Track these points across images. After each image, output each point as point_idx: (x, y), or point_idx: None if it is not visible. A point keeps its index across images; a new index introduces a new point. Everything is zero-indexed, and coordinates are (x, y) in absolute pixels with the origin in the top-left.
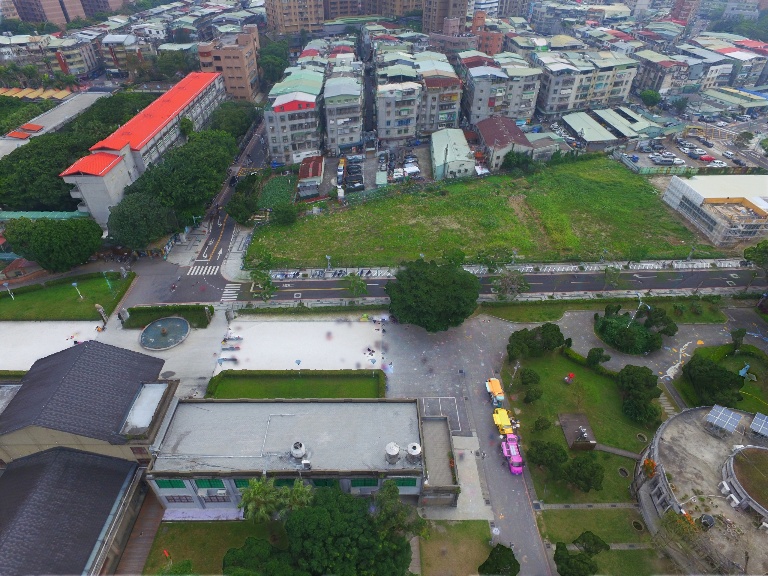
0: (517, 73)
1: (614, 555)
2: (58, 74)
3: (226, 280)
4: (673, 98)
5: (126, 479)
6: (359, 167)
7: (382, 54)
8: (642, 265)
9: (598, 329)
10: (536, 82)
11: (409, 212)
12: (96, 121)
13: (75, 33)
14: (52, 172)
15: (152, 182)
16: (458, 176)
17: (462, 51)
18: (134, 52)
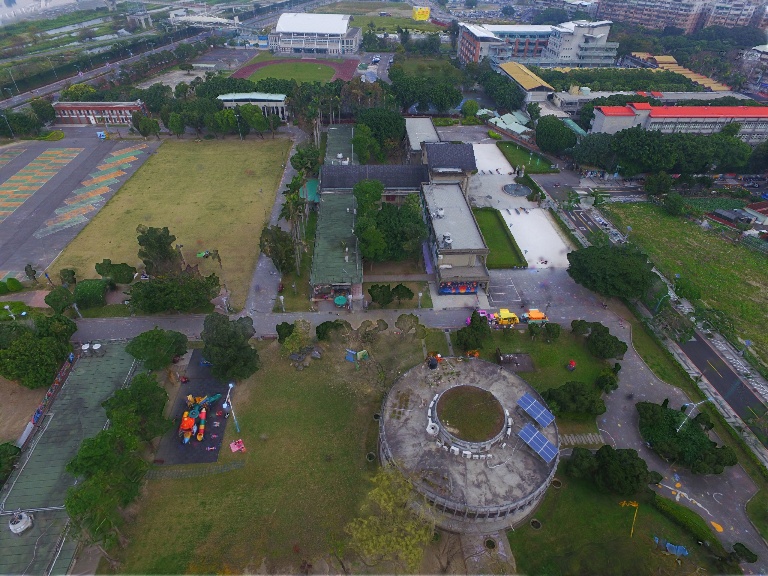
0: None
1: (421, 359)
2: (737, 74)
3: None
4: None
5: None
6: None
7: None
8: None
9: None
10: None
11: None
12: (691, 105)
13: None
14: None
15: (622, 132)
16: None
17: None
18: None
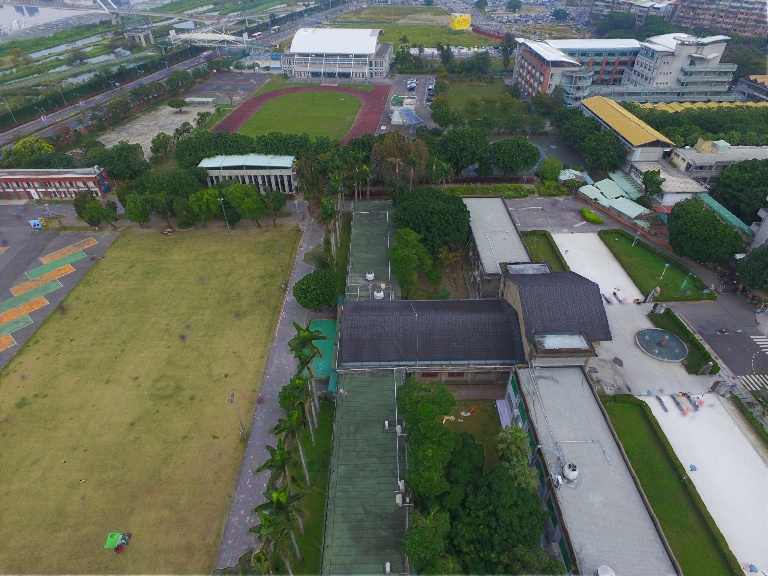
0: None
1: None
2: None
3: None
4: None
5: (511, 360)
6: None
7: None
8: None
9: None
10: None
11: None
12: None
13: None
14: None
15: None
16: None
17: None
18: None
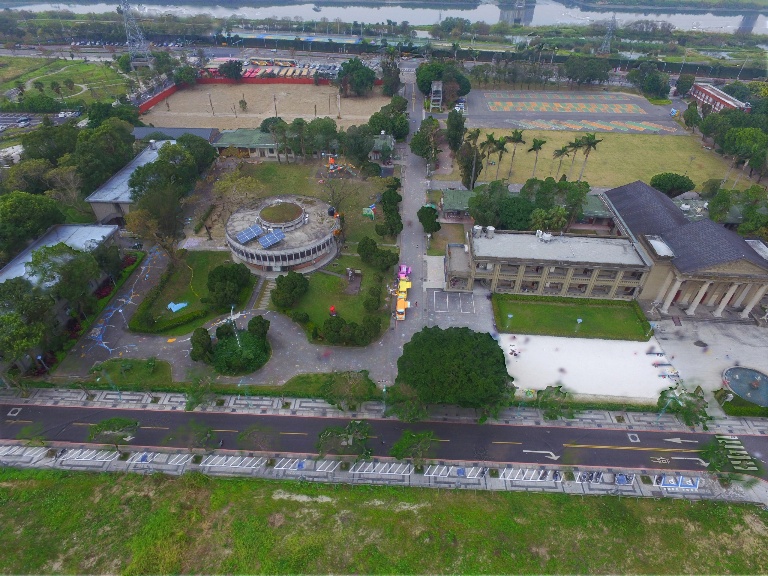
0: None
1: None
2: None
3: None
4: None
5: None
6: None
7: None
8: (94, 459)
9: None
10: None
11: None
12: None
13: None
14: None
15: None
16: None
17: None
18: None
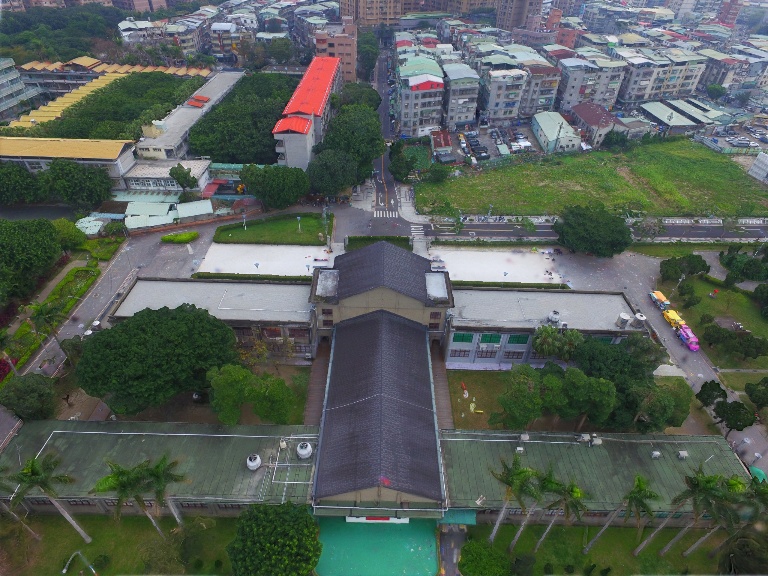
0: (606, 64)
1: None
2: (200, 55)
3: (408, 221)
4: (736, 92)
5: (426, 335)
6: (477, 141)
7: (475, 45)
8: (746, 221)
9: (725, 263)
10: (621, 73)
11: (535, 177)
12: (254, 95)
13: (180, 20)
14: (247, 133)
15: (343, 141)
16: (566, 150)
17: (544, 45)
18: (238, 39)
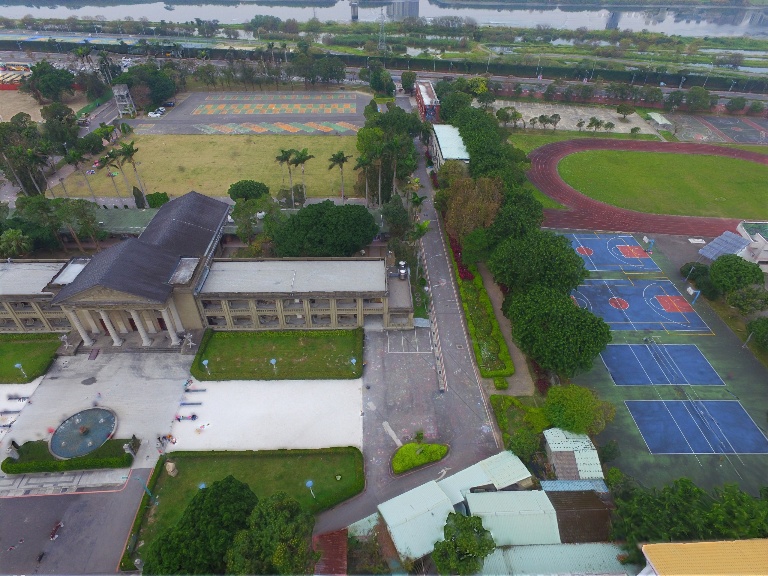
0: None
1: None
2: None
3: None
4: None
5: None
6: None
7: None
8: None
9: None
10: None
11: None
12: None
13: None
14: None
15: None
16: None
17: None
18: None
